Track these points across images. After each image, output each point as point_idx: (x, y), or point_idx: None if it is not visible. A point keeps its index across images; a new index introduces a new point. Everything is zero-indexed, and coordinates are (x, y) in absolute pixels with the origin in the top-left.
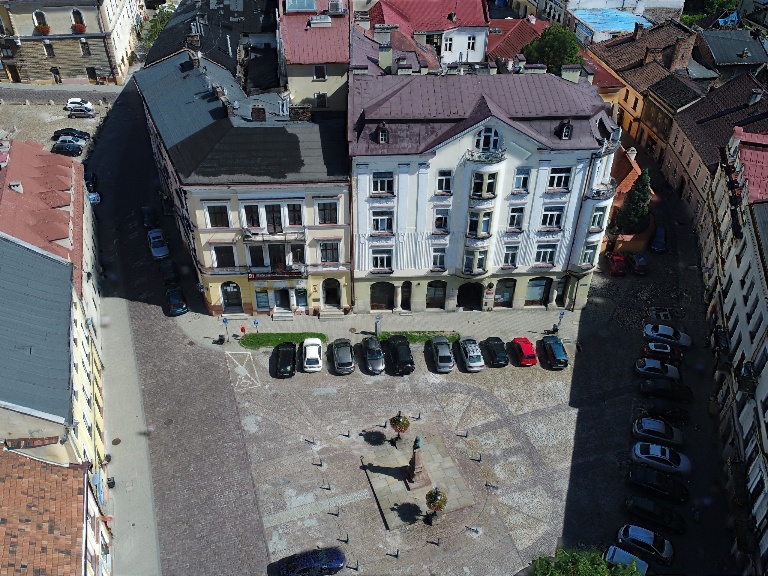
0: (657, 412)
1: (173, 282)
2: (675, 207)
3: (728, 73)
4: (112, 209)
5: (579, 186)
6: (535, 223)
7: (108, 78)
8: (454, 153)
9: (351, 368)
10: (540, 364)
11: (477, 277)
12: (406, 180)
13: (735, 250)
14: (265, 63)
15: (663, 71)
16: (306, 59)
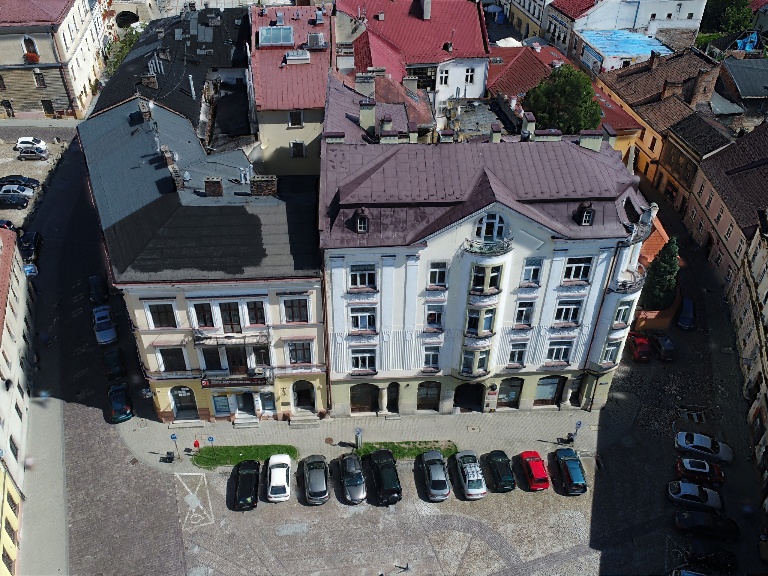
0: (698, 559)
1: (118, 377)
2: (702, 269)
3: (754, 107)
4: (56, 277)
5: (601, 278)
6: (547, 319)
7: (66, 111)
8: (449, 243)
9: (325, 498)
10: (553, 487)
11: (477, 379)
12: (391, 274)
13: None
14: (236, 103)
15: (684, 108)
16: (279, 104)
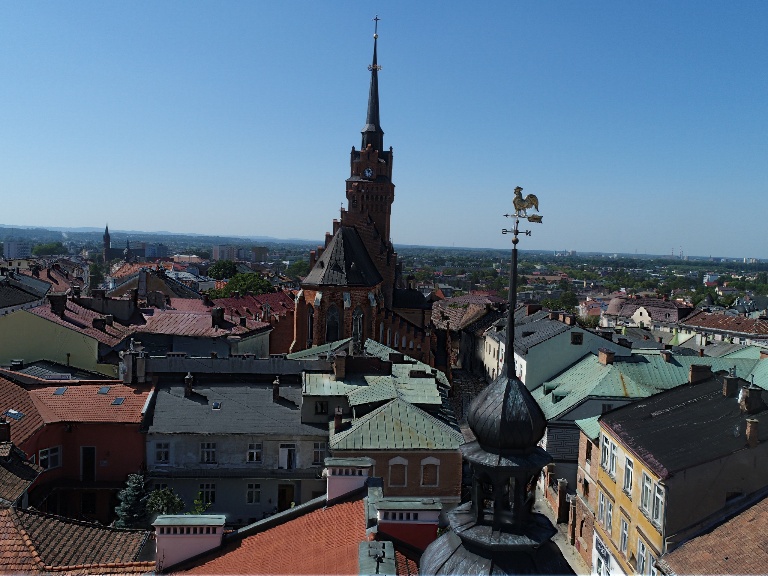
0: None
1: None
2: None
3: None
4: None
5: None
6: None
7: None
8: None
9: None
10: None
11: None
12: None
13: None
14: None
15: None
16: None
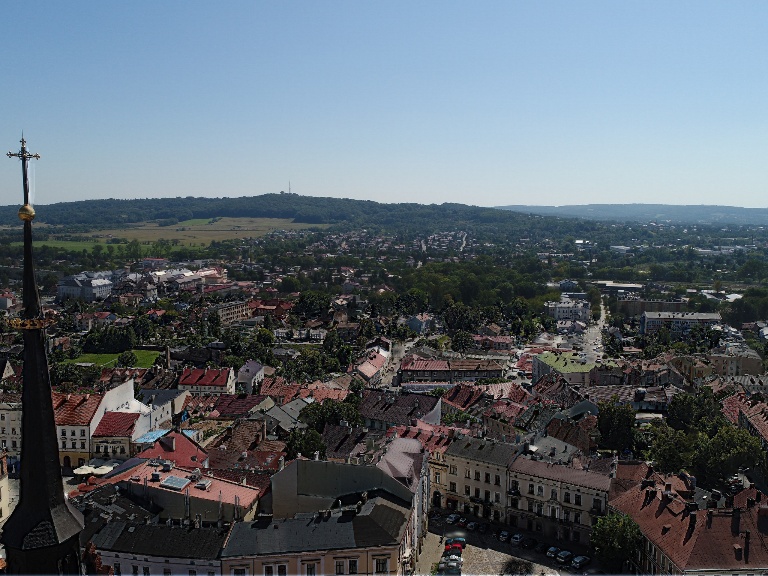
0: None
1: None
2: None
3: None
4: None
5: None
6: None
7: None
8: None
9: None
10: None
11: None
12: None
13: (446, 473)
14: None
15: (275, 442)
16: (246, 501)
